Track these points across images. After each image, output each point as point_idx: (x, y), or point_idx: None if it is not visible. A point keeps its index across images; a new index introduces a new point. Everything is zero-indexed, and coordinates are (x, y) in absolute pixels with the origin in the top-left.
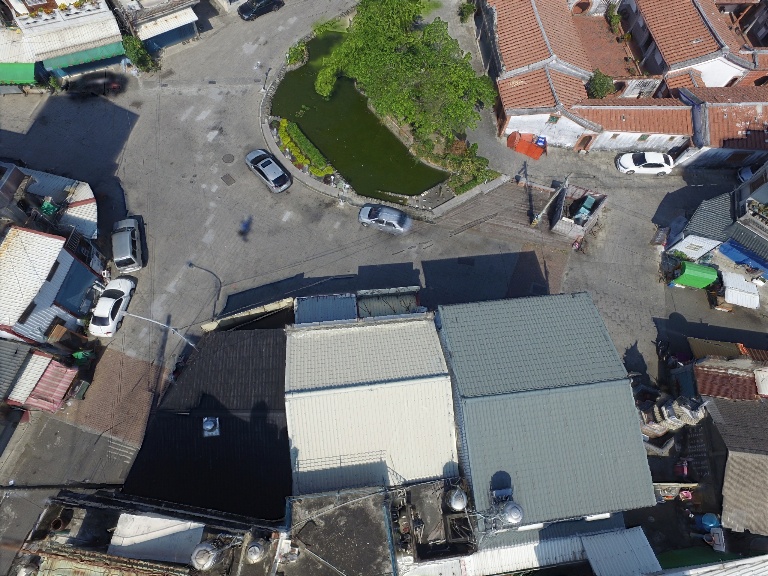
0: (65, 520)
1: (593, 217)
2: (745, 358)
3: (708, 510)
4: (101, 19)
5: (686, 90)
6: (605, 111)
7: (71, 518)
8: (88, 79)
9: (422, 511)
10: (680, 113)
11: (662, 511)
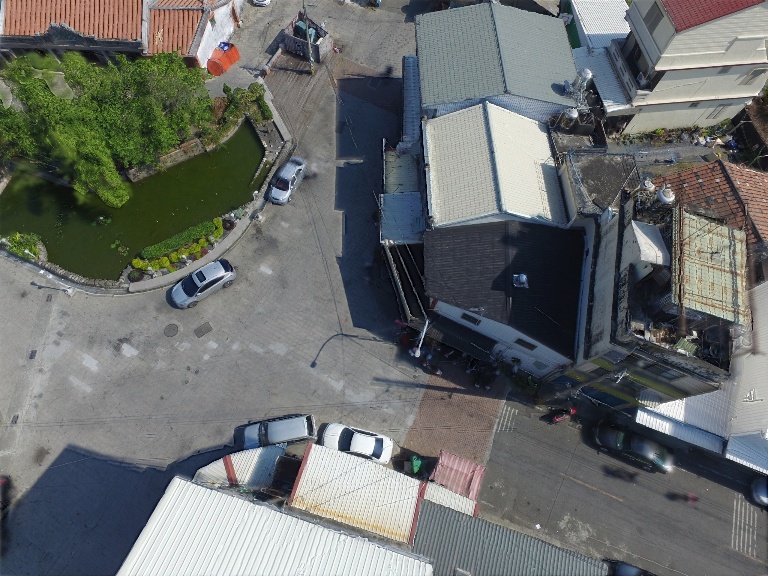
0: None
1: None
2: None
3: None
4: None
5: None
6: None
7: None
8: None
9: None
10: None
11: None
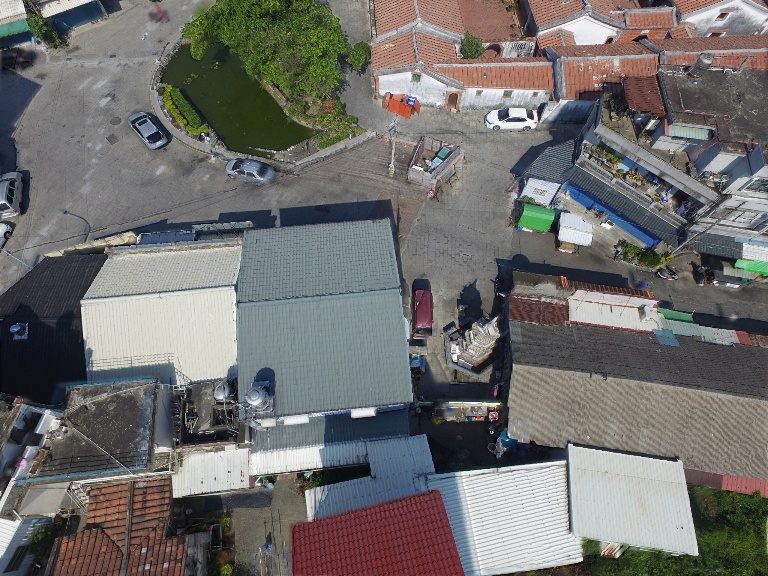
0: None
1: (448, 167)
2: (547, 282)
3: (505, 426)
4: None
5: (550, 48)
6: (466, 69)
7: None
8: (2, 55)
9: (199, 406)
10: (541, 69)
11: (471, 431)
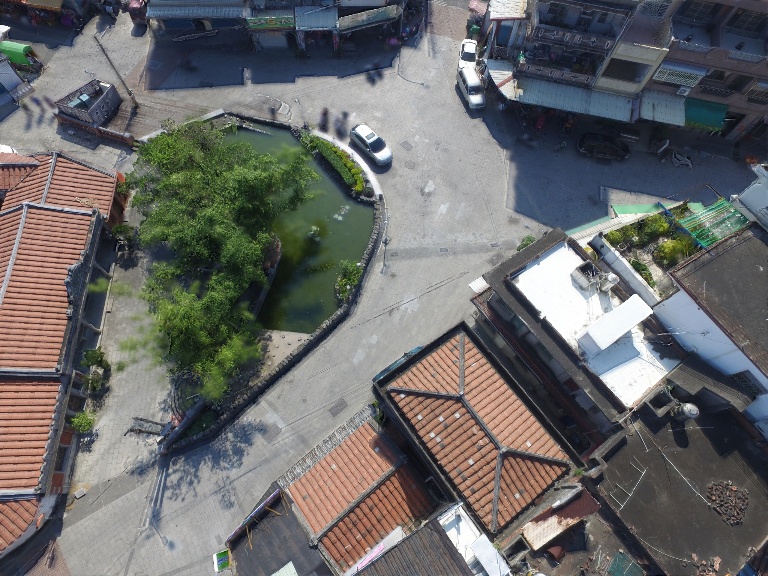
0: None
1: None
2: None
3: None
4: None
5: None
6: None
7: None
8: None
9: None
10: None
11: None
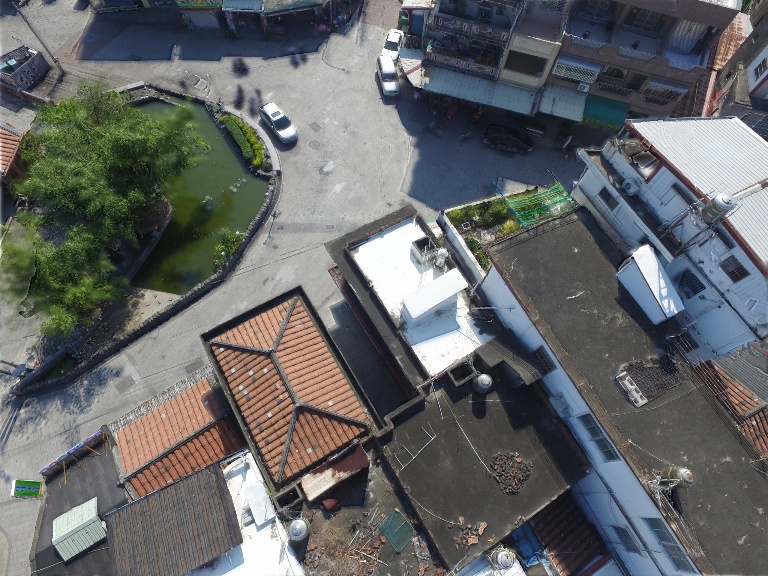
0: None
1: None
2: None
3: None
4: None
5: None
6: None
7: None
8: None
9: None
10: None
11: None
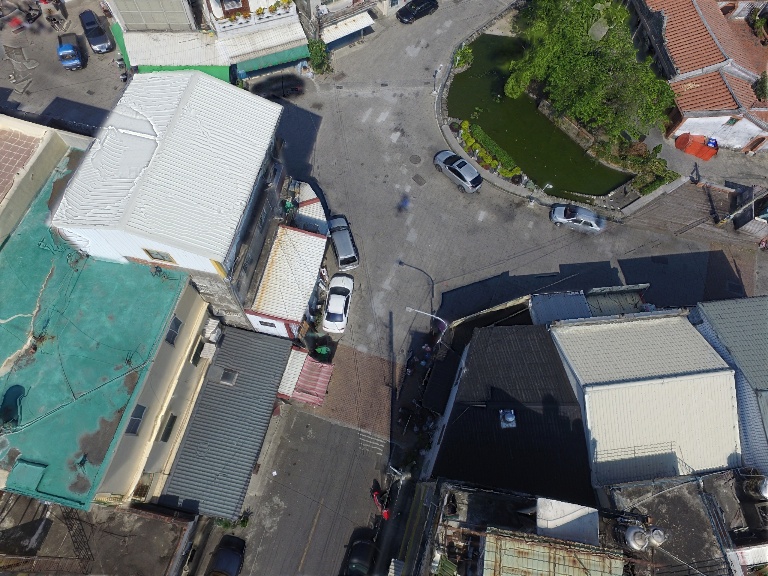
0: (456, 505)
1: None
2: None
3: None
4: (287, 23)
5: None
6: None
7: (456, 503)
8: (266, 81)
9: (719, 500)
10: None
11: None
